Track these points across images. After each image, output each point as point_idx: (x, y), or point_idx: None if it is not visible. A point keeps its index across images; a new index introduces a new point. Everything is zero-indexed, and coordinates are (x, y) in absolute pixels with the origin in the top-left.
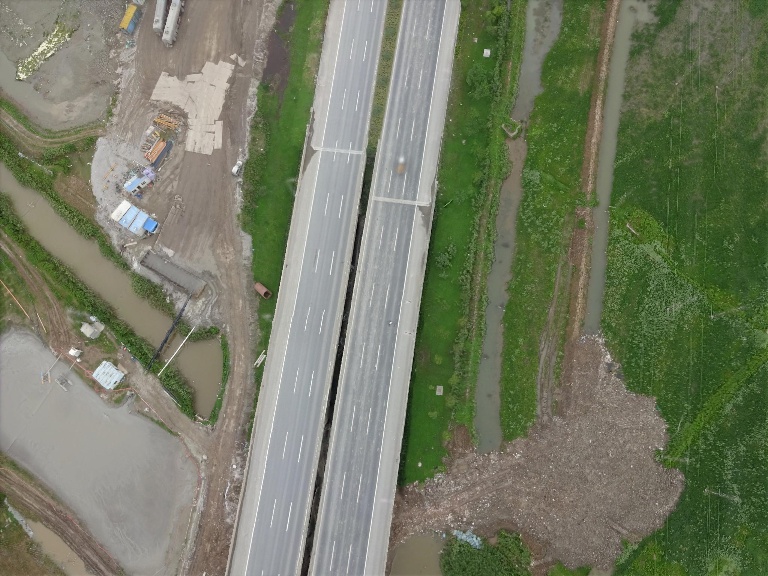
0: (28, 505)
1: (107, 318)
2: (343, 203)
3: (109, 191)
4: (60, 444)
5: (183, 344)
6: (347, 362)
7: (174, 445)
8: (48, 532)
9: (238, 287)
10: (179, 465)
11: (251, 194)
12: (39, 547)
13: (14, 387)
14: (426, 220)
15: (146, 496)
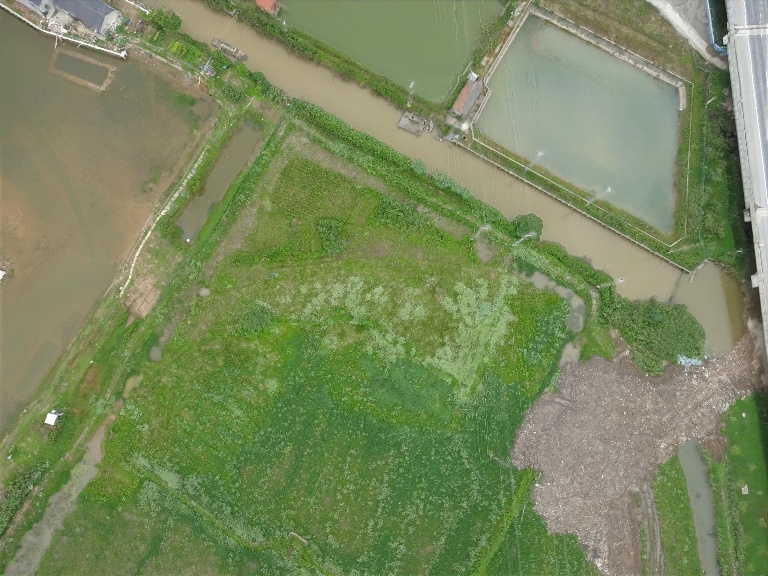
0: None
1: None
2: None
3: None
4: None
5: None
6: None
7: None
8: None
9: None
10: None
11: None
12: None
13: None
14: None
15: None
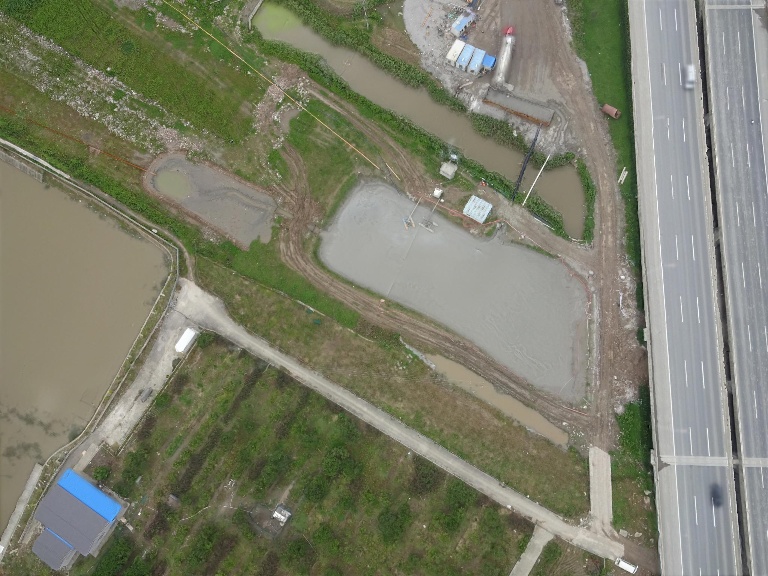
0: (424, 341)
1: (459, 158)
2: (677, 16)
3: (431, 36)
4: (439, 282)
5: (541, 173)
6: (719, 163)
7: (554, 267)
8: (450, 363)
9: (586, 111)
10: (564, 285)
11: (579, 20)
12: (444, 377)
13: (377, 237)
14: (765, 21)
15: (538, 317)
